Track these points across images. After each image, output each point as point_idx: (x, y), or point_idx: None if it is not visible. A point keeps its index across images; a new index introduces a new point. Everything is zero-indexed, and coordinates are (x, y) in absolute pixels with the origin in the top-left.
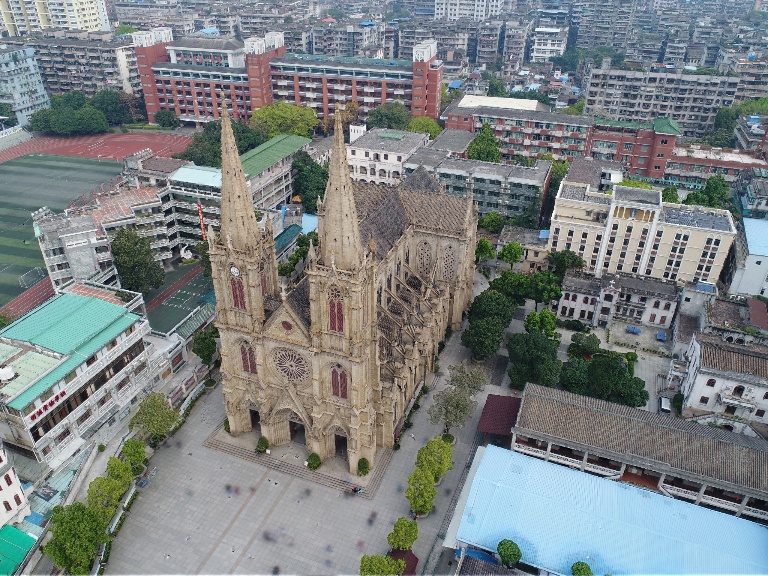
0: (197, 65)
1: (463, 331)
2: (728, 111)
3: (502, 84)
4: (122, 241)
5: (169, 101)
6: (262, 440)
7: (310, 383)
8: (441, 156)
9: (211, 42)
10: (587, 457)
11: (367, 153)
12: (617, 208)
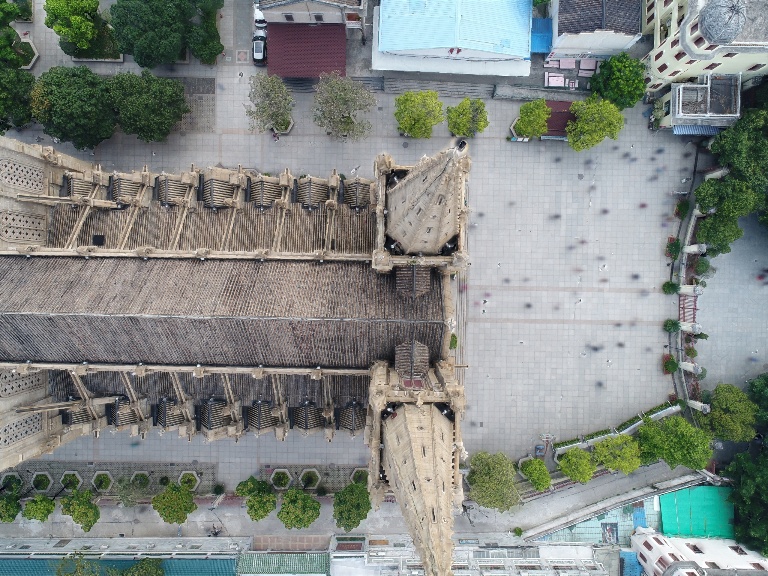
0: None
1: None
2: None
3: None
4: None
5: None
6: (452, 341)
7: None
8: None
9: None
10: None
11: None
12: None
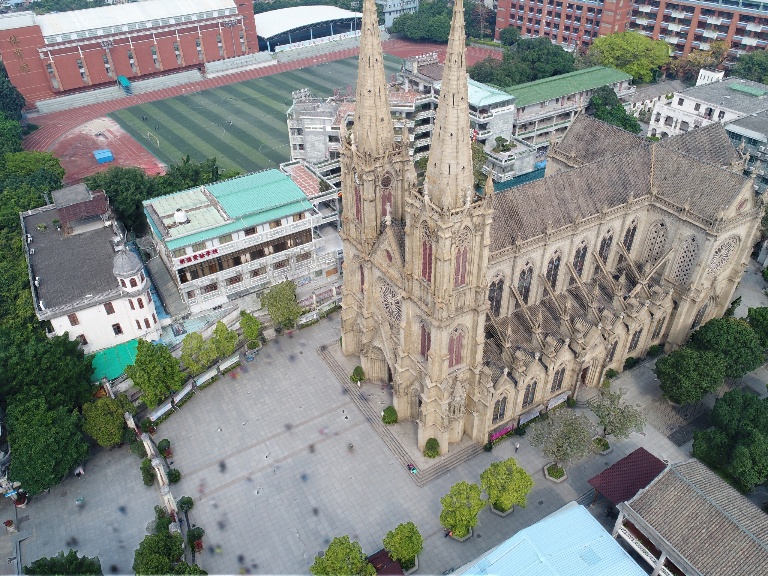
0: None
1: None
2: None
3: None
4: None
5: (519, 18)
6: (357, 369)
7: None
8: None
9: None
10: None
11: (698, 105)
12: None
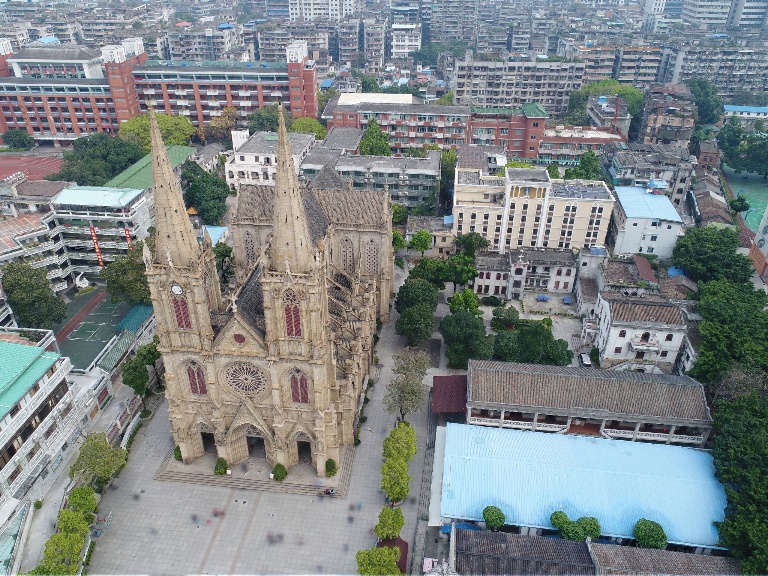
0: (47, 78)
1: (392, 321)
2: (579, 93)
3: (374, 80)
4: (15, 276)
5: (18, 119)
6: (221, 461)
7: (268, 393)
8: (335, 154)
9: (61, 52)
10: (537, 418)
11: (257, 158)
12: (513, 188)
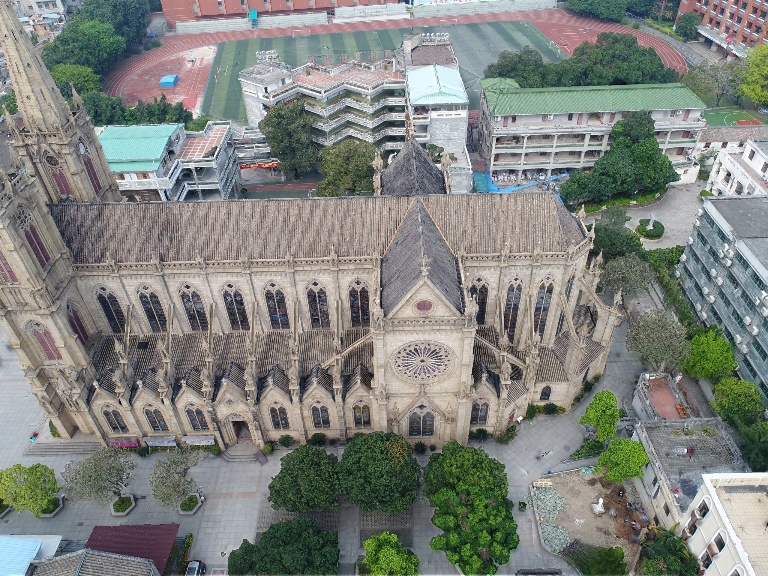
0: None
1: None
2: None
3: None
4: None
5: (707, 3)
6: None
7: None
8: None
9: None
10: None
11: (766, 165)
12: None
